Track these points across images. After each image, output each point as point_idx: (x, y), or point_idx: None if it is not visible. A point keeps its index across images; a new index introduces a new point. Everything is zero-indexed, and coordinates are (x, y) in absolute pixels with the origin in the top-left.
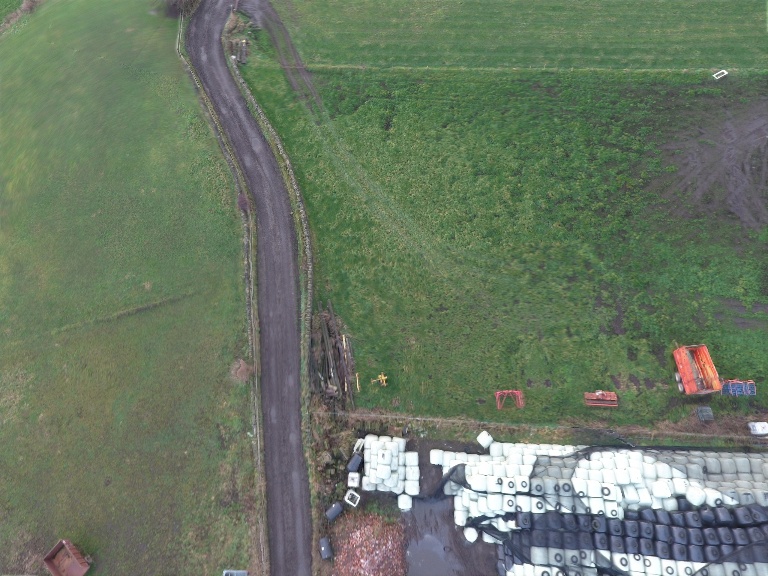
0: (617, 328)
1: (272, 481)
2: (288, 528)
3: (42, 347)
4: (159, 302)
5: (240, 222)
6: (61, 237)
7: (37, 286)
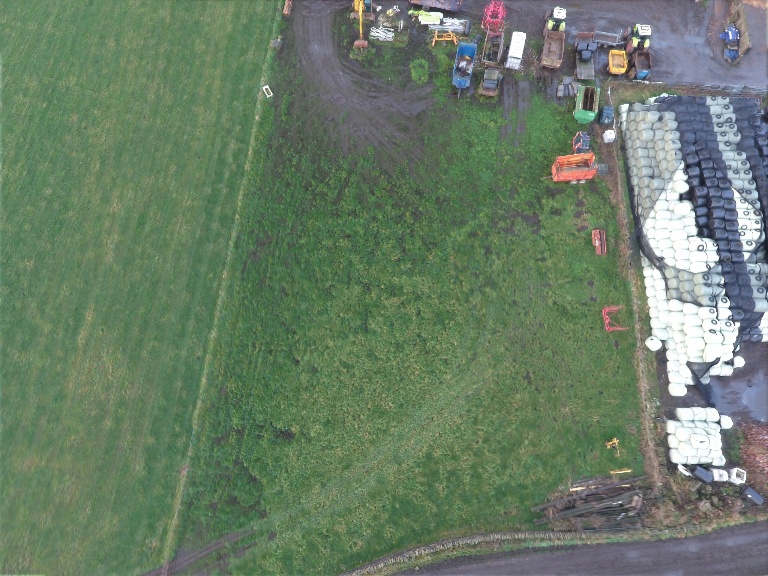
0: (533, 220)
1: (743, 570)
2: None
3: None
4: None
5: None
6: None
7: None
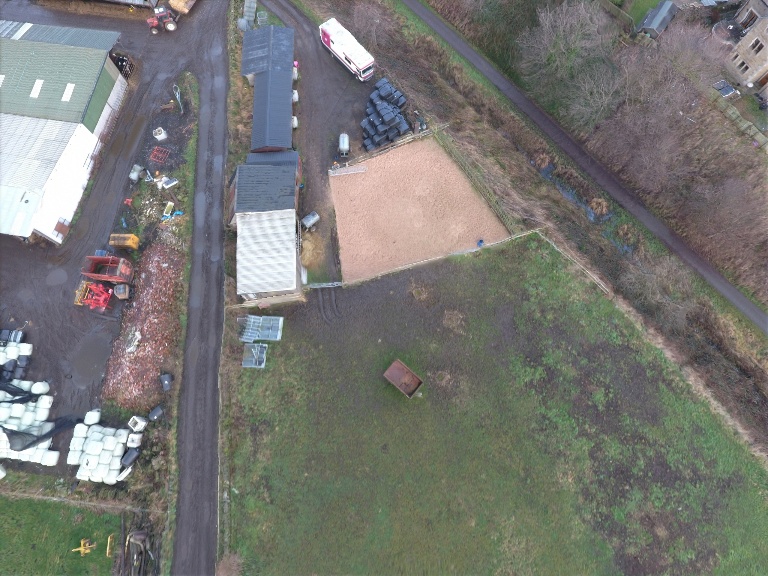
0: None
1: (213, 442)
2: (201, 400)
3: None
4: None
5: None
6: None
7: None
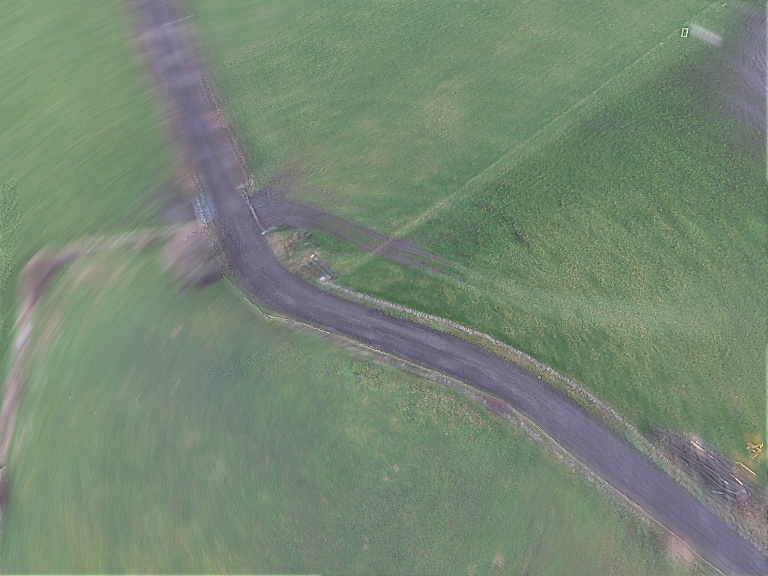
0: None
1: None
2: None
3: None
4: (527, 566)
5: (509, 425)
6: None
7: None
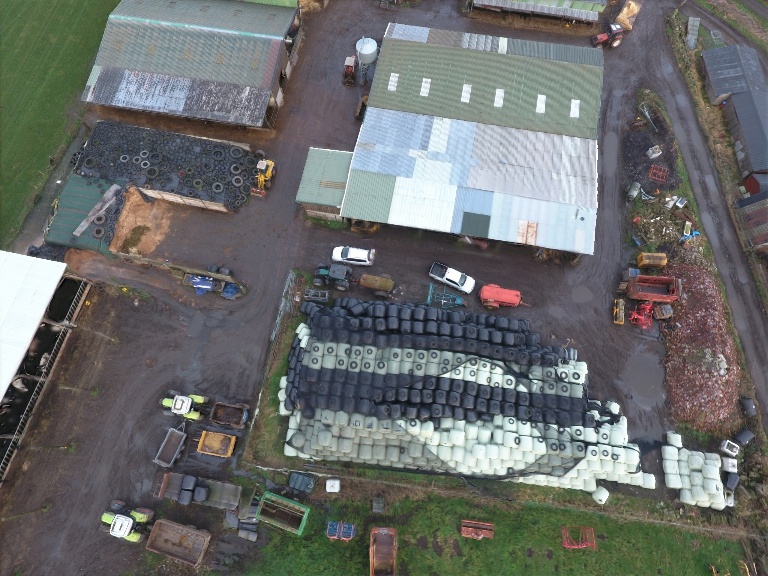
0: None
1: None
2: None
3: None
4: None
5: None
6: None
7: None
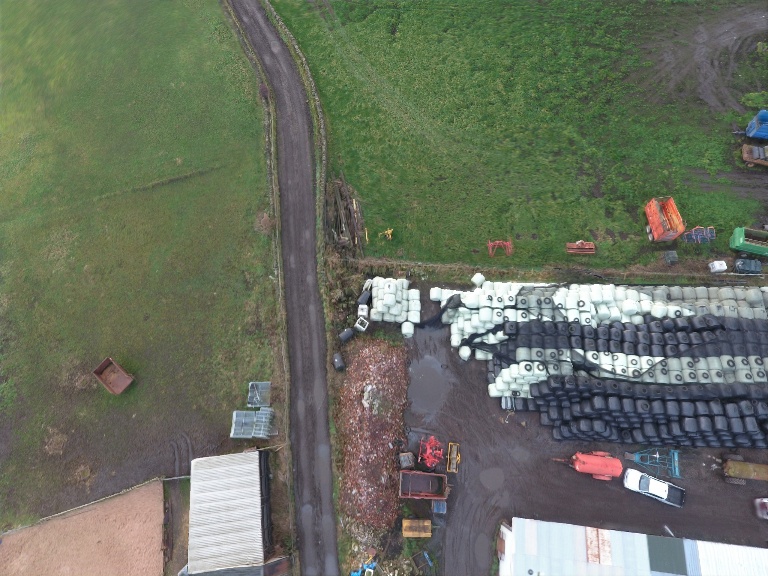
0: (596, 192)
1: (291, 312)
2: (306, 348)
3: (85, 211)
4: (189, 174)
5: (261, 109)
6: (100, 123)
7: (79, 163)
